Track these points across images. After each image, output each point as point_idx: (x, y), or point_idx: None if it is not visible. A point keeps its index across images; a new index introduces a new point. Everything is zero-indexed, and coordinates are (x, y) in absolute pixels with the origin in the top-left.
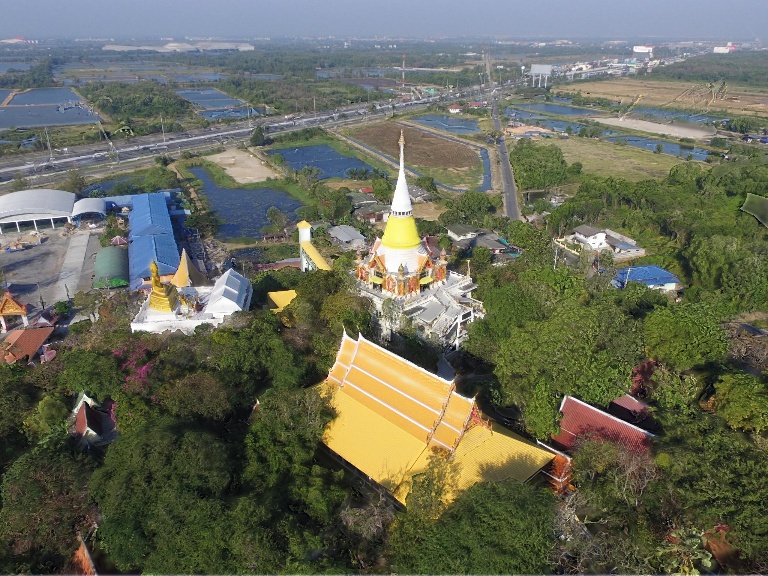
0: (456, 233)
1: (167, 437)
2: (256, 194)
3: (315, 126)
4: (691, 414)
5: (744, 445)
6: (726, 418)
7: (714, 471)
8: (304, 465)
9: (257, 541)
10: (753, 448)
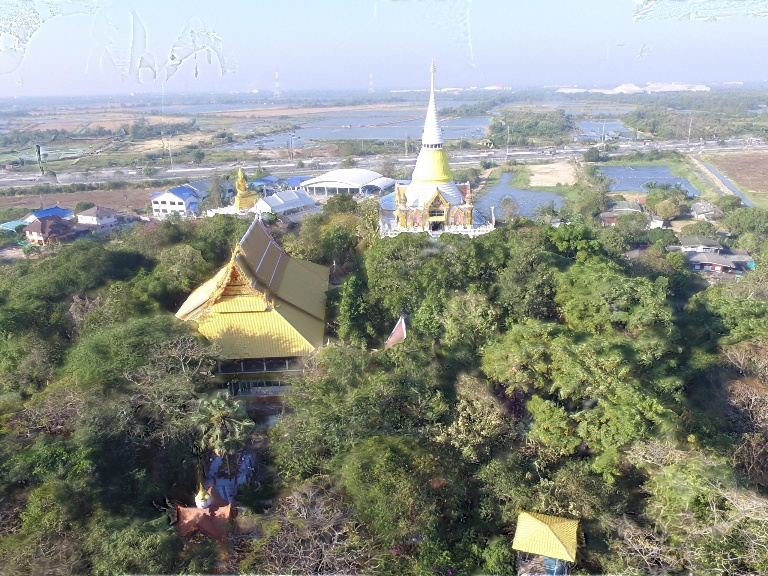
0: (683, 243)
1: (79, 243)
2: (533, 194)
3: (670, 149)
4: (450, 346)
5: (419, 369)
6: (485, 362)
7: (348, 375)
8: (148, 295)
9: (25, 299)
10: (428, 376)
